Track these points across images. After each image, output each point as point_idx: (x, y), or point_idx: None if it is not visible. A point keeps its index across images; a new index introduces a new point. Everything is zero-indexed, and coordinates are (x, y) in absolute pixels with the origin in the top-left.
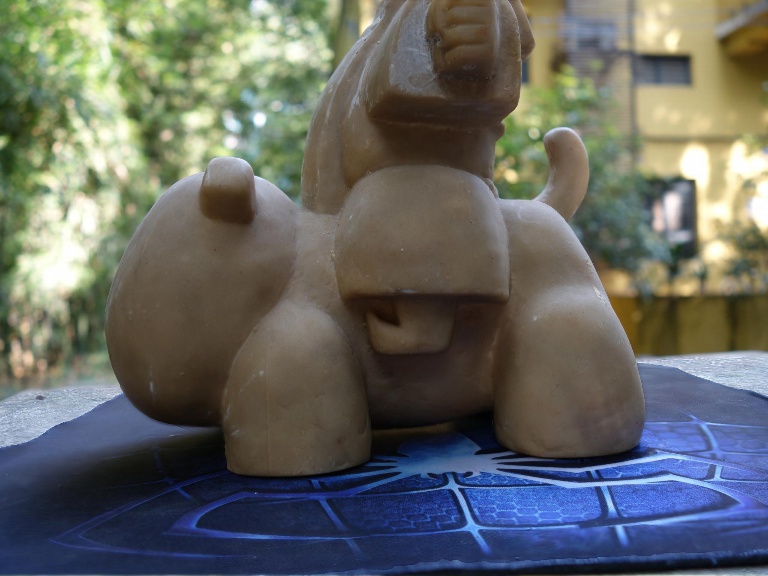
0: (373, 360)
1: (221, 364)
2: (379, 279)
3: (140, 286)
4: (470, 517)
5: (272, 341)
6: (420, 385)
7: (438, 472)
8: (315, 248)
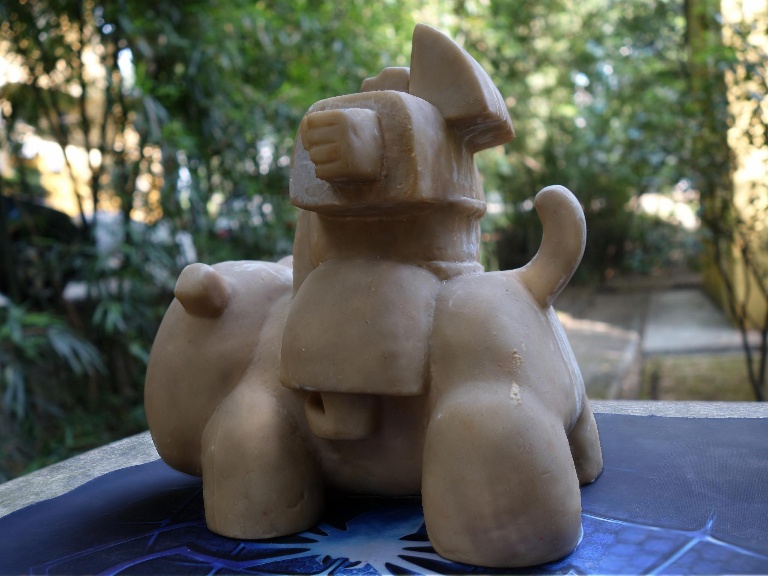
0: None
1: (195, 435)
2: (290, 375)
3: (148, 368)
4: None
5: (223, 421)
6: (365, 463)
7: (336, 556)
8: (274, 335)
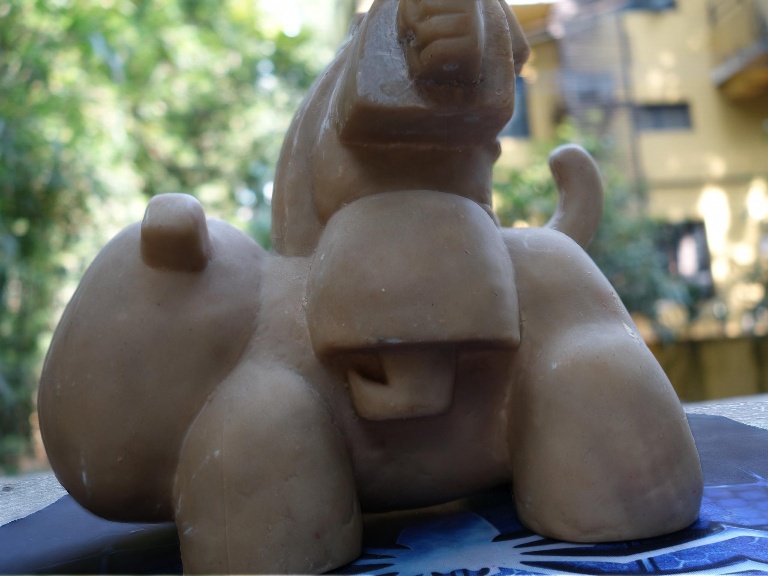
0: (360, 429)
1: (169, 444)
2: (357, 328)
3: (70, 353)
4: None
5: (230, 412)
6: (419, 456)
7: (445, 570)
8: (283, 296)
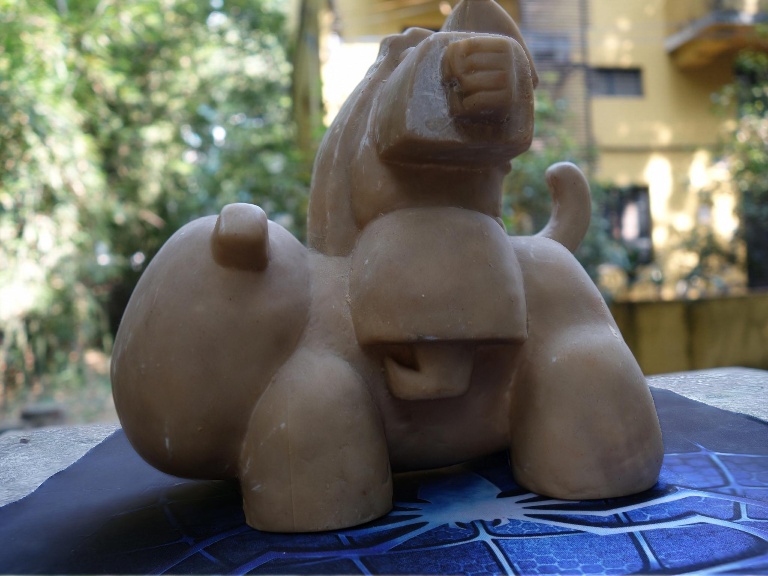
0: (391, 405)
1: (240, 417)
2: (400, 326)
3: (153, 338)
4: (513, 574)
5: (292, 392)
6: (438, 428)
7: (466, 521)
8: (330, 293)
